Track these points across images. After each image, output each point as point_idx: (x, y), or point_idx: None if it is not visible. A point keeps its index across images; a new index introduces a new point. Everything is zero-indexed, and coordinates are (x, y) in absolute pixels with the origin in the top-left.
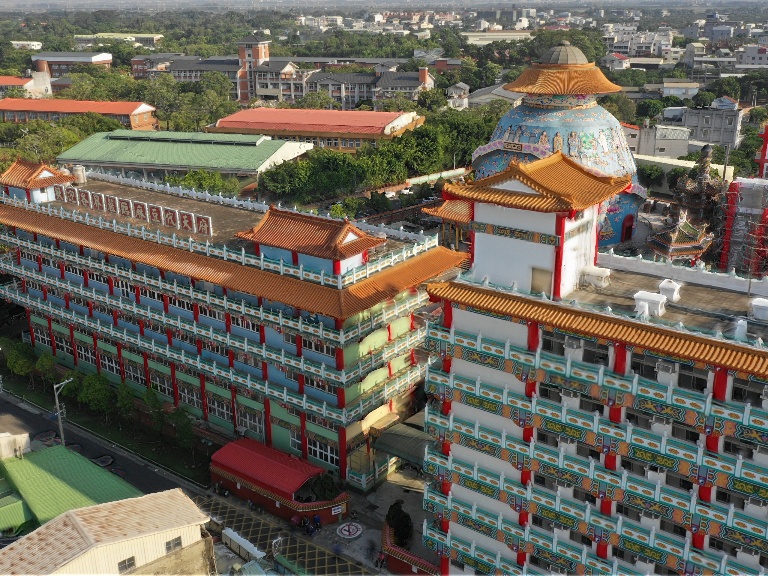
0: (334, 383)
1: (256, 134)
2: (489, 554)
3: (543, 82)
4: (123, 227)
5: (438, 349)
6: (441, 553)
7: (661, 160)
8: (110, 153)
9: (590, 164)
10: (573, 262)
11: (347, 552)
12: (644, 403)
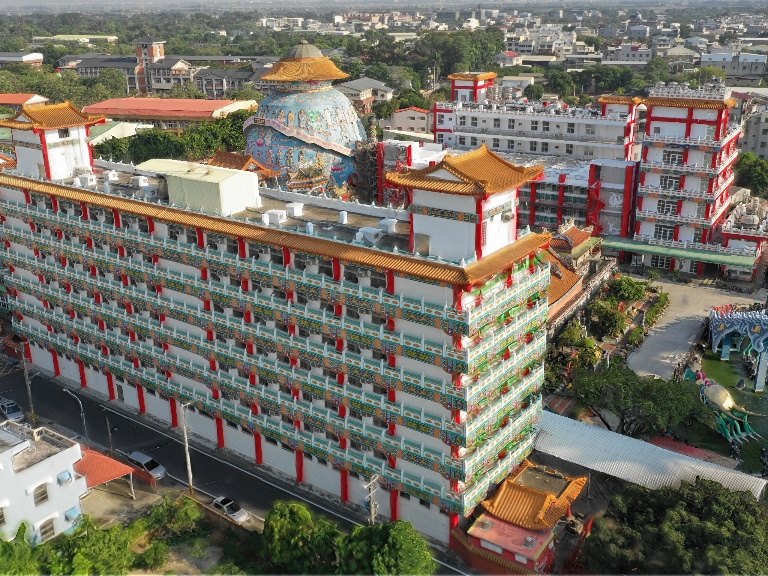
0: None
1: None
2: (36, 330)
3: (282, 72)
4: None
5: None
6: (20, 335)
7: (426, 136)
8: None
9: (315, 134)
10: (64, 161)
11: None
12: (62, 226)
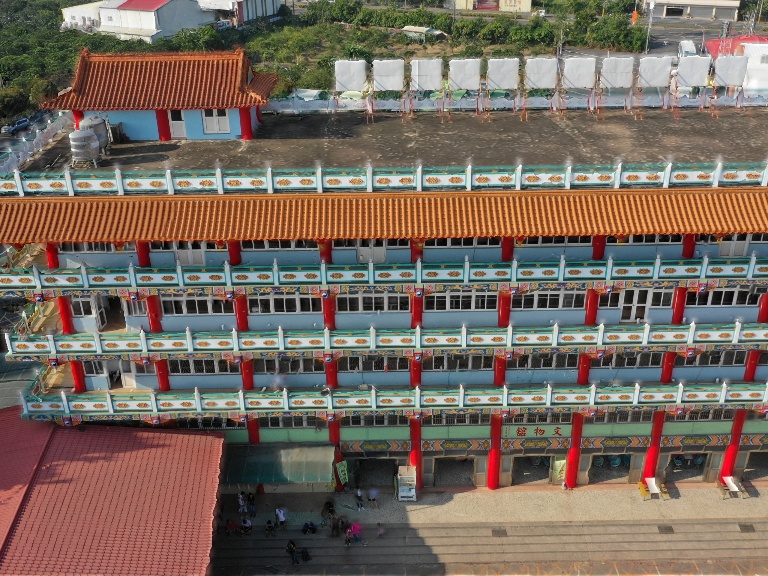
0: None
1: None
2: None
3: None
4: (534, 100)
5: None
6: None
7: None
8: None
9: None
10: None
11: None
12: None
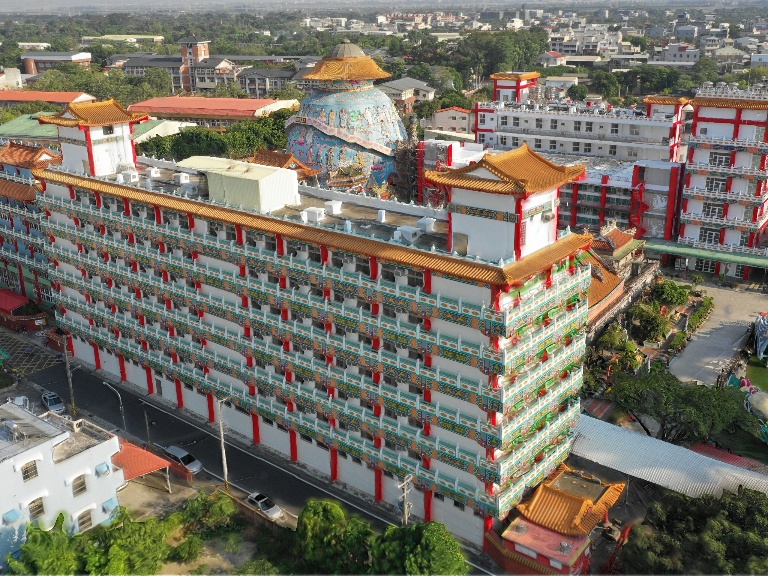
0: (35, 244)
1: (155, 116)
2: (79, 324)
3: (324, 71)
4: None
5: (41, 206)
6: (63, 328)
7: (467, 136)
8: (28, 129)
9: (356, 133)
10: (108, 158)
11: (34, 341)
12: (105, 221)
